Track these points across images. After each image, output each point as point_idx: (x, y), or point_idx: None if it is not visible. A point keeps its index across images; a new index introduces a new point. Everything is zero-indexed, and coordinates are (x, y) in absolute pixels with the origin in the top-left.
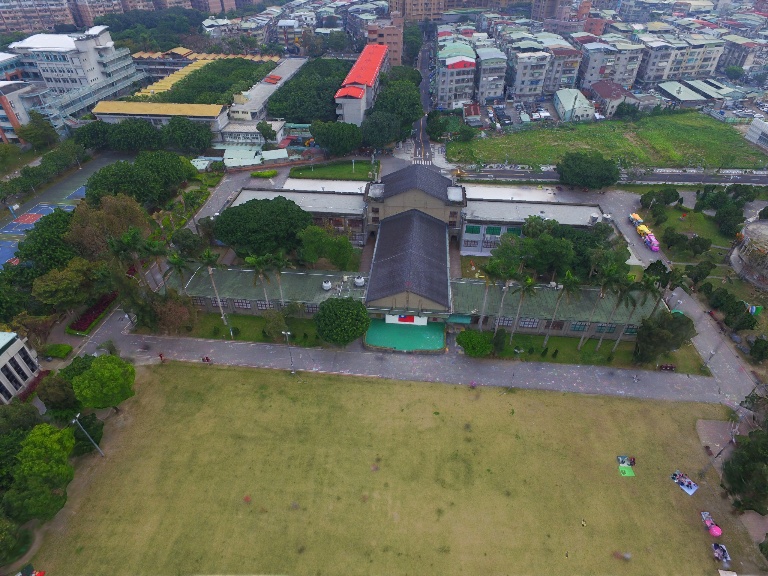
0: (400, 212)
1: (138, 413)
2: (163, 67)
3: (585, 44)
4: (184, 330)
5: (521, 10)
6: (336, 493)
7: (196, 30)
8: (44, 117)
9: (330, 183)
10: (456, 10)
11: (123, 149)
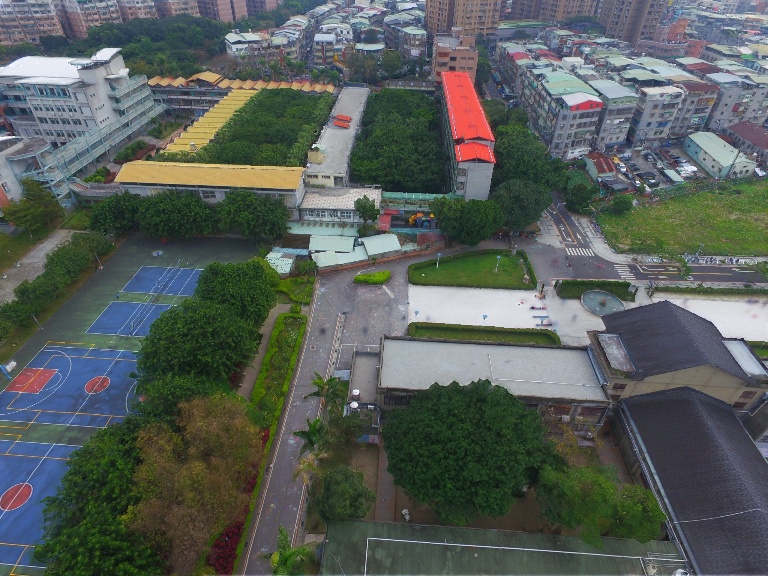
0: (659, 390)
1: None
2: (187, 97)
3: (708, 74)
4: None
5: (590, 26)
6: None
7: (212, 44)
8: (42, 184)
9: (473, 294)
10: (506, 23)
11: (162, 236)
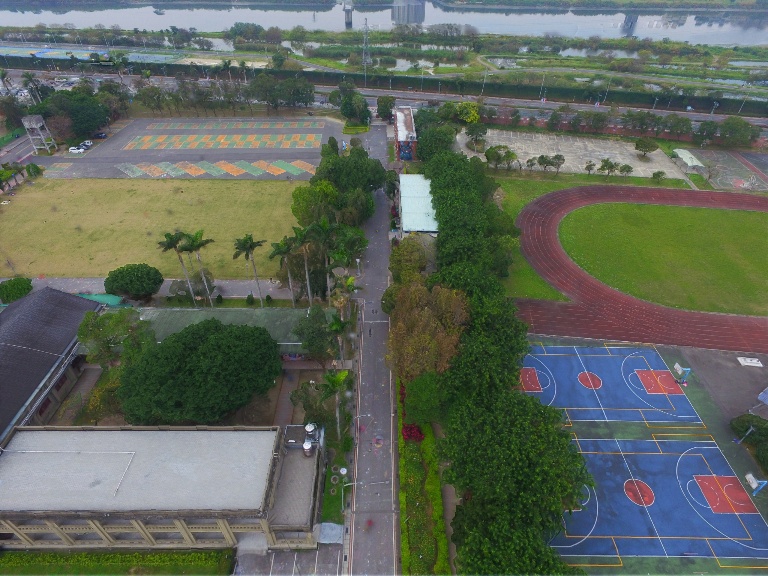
0: None
1: None
2: None
3: None
4: (303, 302)
5: None
6: None
7: None
8: None
9: None
10: None
11: None
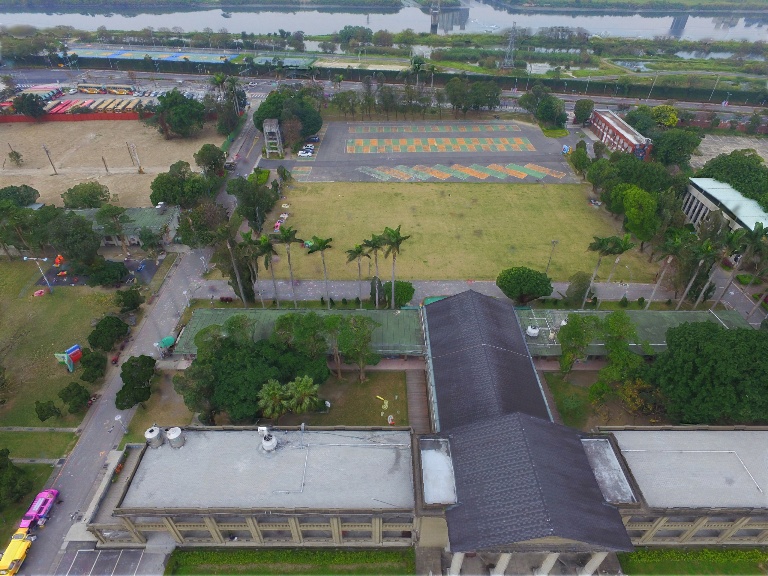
0: None
1: (628, 252)
2: None
3: None
4: (673, 304)
5: None
6: (476, 228)
7: None
8: None
9: None
10: None
11: None
